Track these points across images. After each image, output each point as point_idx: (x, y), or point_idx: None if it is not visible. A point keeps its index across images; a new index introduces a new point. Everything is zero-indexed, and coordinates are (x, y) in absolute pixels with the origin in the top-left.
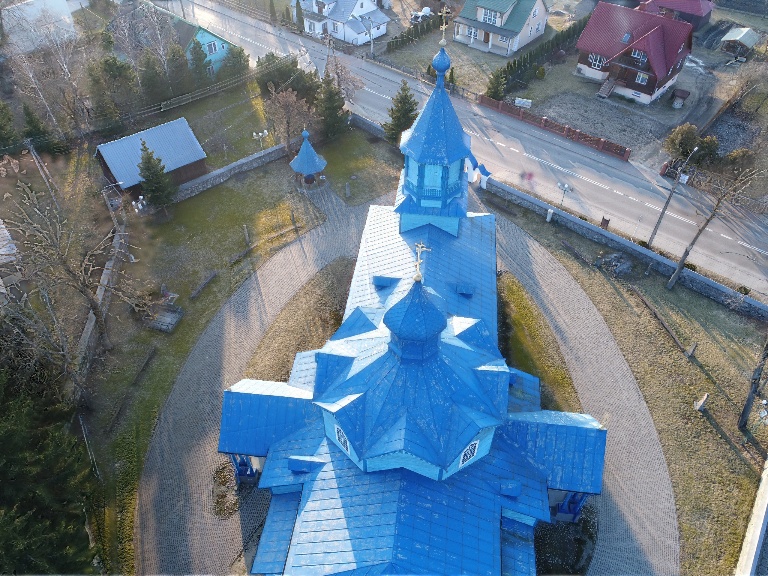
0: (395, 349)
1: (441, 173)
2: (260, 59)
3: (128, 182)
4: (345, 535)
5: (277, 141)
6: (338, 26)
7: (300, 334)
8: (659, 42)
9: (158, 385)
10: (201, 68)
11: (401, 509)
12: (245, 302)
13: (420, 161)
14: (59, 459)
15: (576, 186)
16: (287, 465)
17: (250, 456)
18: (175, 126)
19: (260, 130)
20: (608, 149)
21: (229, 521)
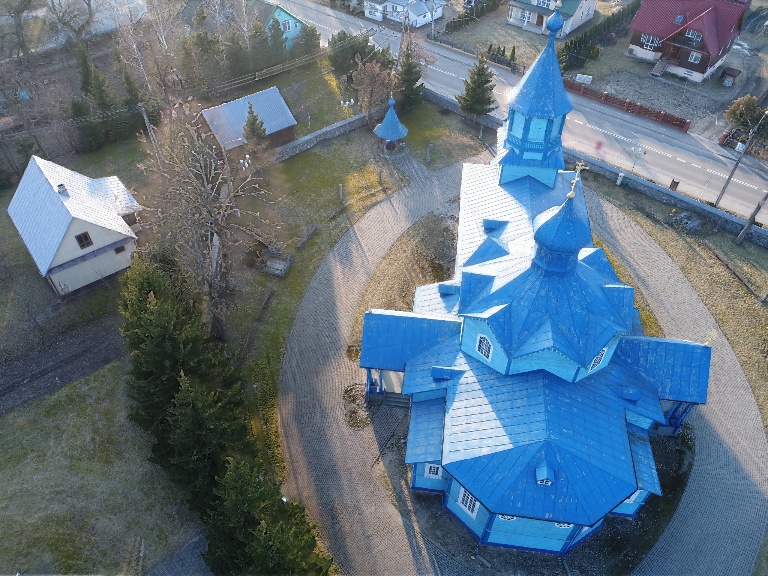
0: (540, 263)
1: (545, 126)
2: (334, 37)
3: (229, 145)
4: (497, 424)
5: (354, 112)
6: (398, 9)
7: (402, 279)
8: (712, 23)
9: (280, 321)
10: (278, 45)
11: (547, 401)
12: (347, 252)
13: (529, 114)
14: (224, 368)
15: None
16: (428, 375)
17: (376, 378)
18: (268, 94)
19: (337, 103)
20: (668, 121)
21: (364, 432)
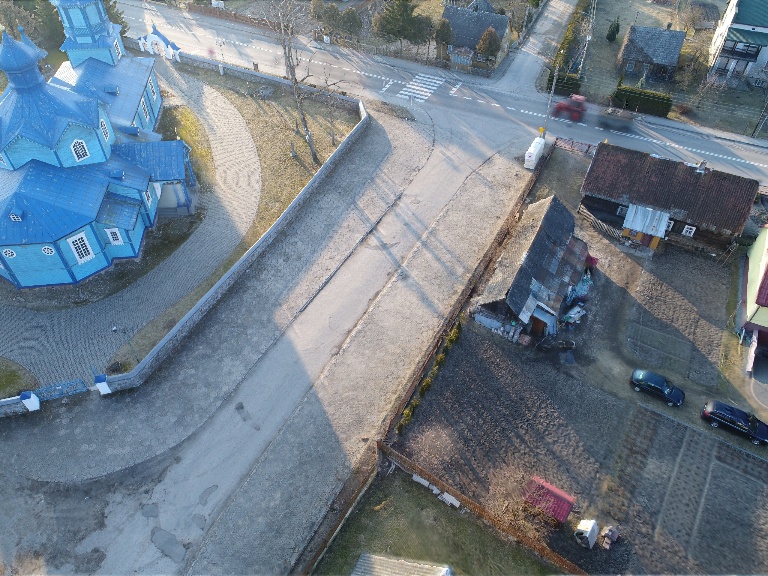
0: (11, 85)
1: (81, 15)
2: None
3: None
4: None
5: None
6: None
7: None
8: None
9: None
10: None
11: (28, 174)
12: None
13: (60, 5)
14: None
15: (249, 53)
16: None
17: None
18: None
19: None
20: (278, 28)
21: None
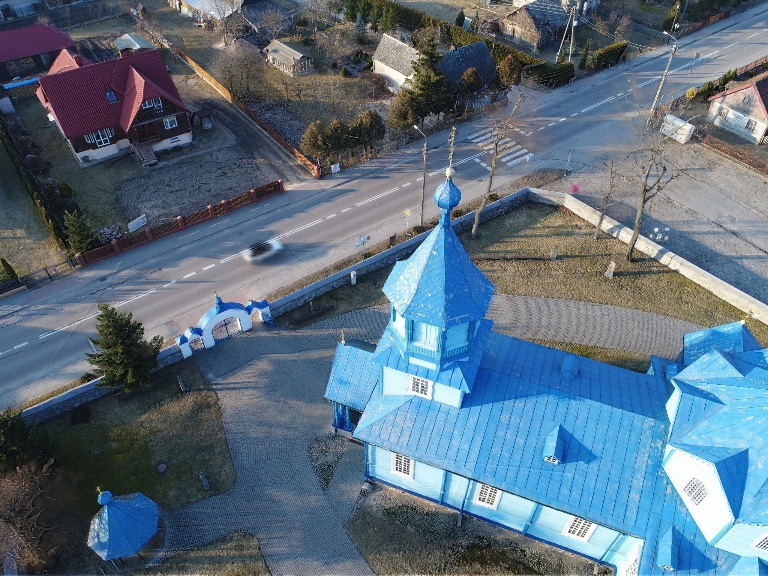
0: None
1: None
2: None
3: None
4: None
5: None
6: None
7: None
8: (151, 81)
9: None
10: None
11: None
12: None
13: None
14: None
15: (306, 241)
16: None
17: None
18: None
19: None
20: (262, 195)
21: None
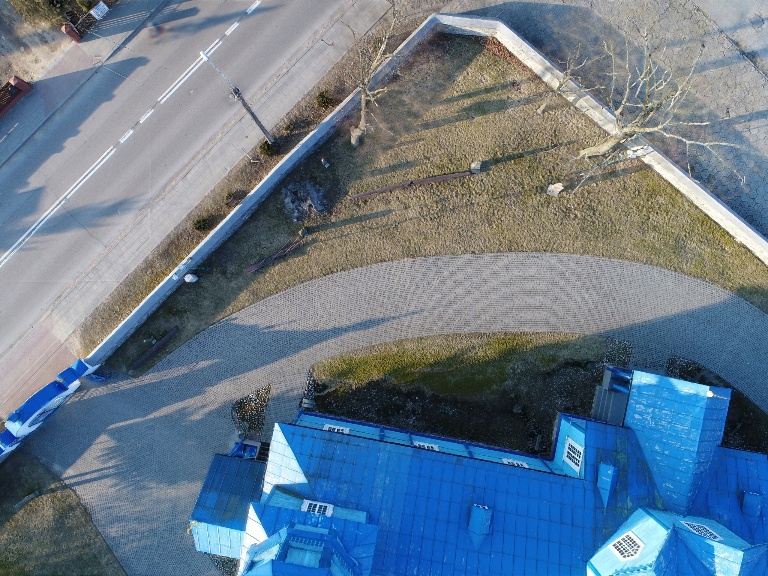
0: None
1: None
2: None
3: None
4: None
5: None
6: None
7: None
8: None
9: None
10: None
11: None
12: None
13: None
14: None
15: (102, 204)
16: None
17: None
18: None
19: None
20: None
21: None
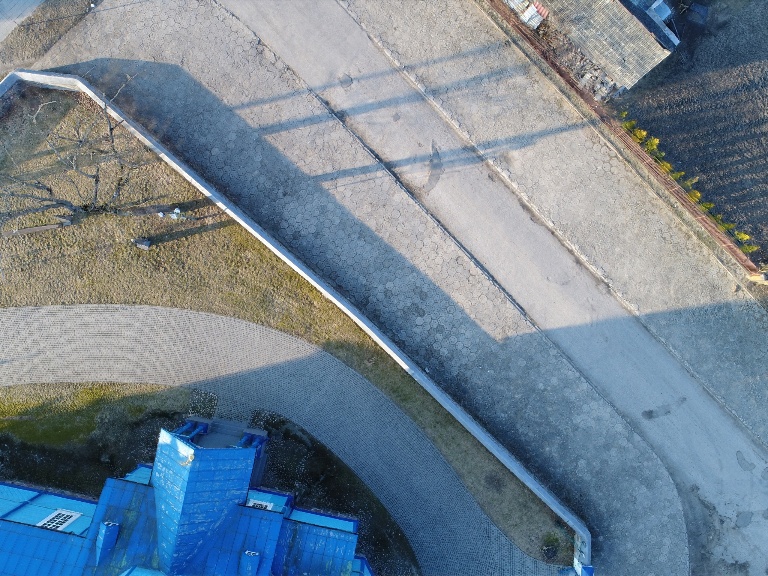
0: None
1: None
2: None
3: None
4: None
5: None
6: None
7: None
8: None
9: None
10: None
11: None
12: None
13: None
14: None
15: None
16: None
17: None
18: None
19: None
20: None
21: None
